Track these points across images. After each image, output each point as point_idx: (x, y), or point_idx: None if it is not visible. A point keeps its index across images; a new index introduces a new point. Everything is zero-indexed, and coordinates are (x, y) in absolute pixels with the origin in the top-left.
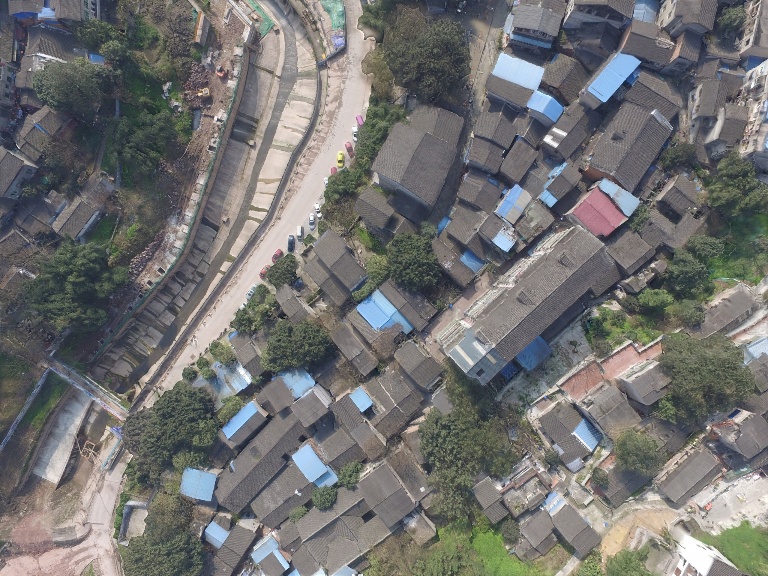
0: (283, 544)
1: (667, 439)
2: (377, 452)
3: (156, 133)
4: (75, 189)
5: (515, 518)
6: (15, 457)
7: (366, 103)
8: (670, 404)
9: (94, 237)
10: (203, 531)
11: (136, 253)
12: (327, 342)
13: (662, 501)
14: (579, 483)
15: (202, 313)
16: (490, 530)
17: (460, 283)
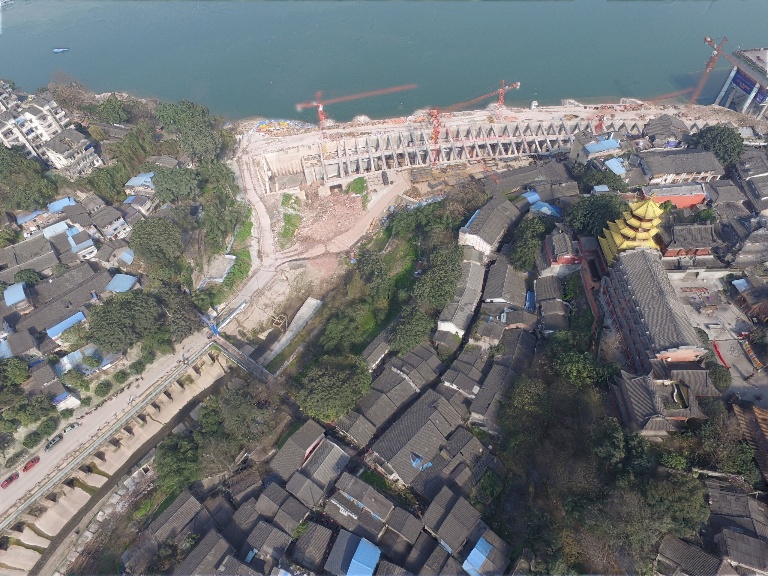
0: None
1: None
2: None
3: None
4: None
5: None
6: None
7: None
8: None
9: None
10: None
11: None
12: None
13: None
14: None
15: None
16: None
17: None
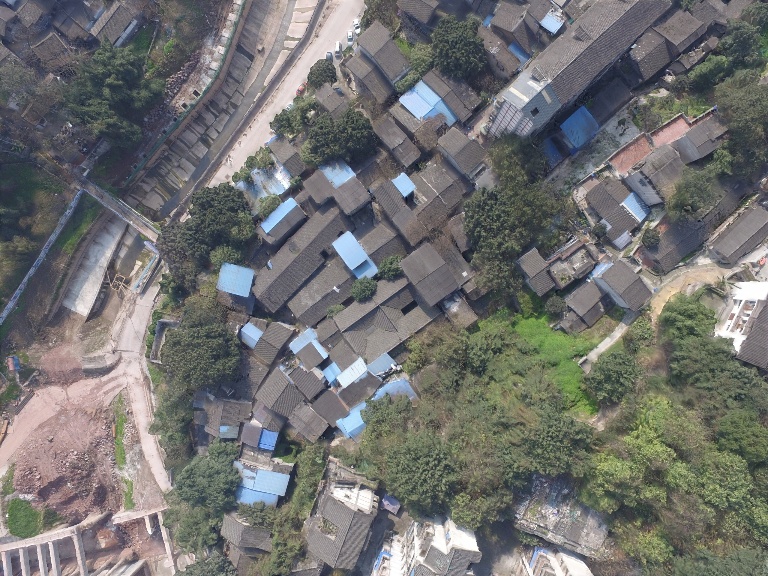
0: (321, 339)
1: (720, 199)
2: (419, 236)
3: None
4: None
5: (560, 295)
6: (46, 283)
7: None
8: (726, 151)
9: None
10: (239, 330)
11: (172, 72)
12: (370, 128)
13: (713, 264)
14: (626, 256)
15: (237, 134)
16: (533, 315)
17: (504, 75)
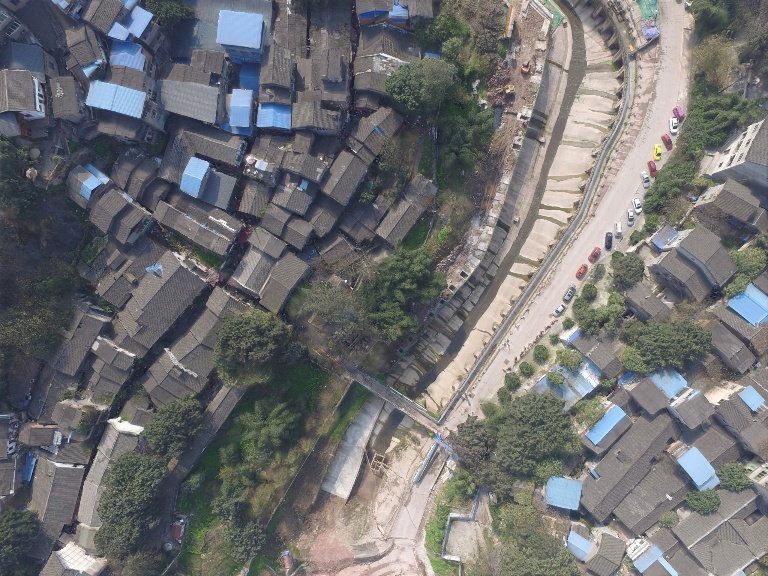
0: None
1: None
2: None
3: (481, 132)
4: (401, 193)
5: None
6: (313, 473)
7: (681, 93)
8: None
9: (409, 242)
10: (566, 541)
11: (442, 257)
12: (710, 340)
13: None
14: None
15: (511, 316)
16: None
17: None
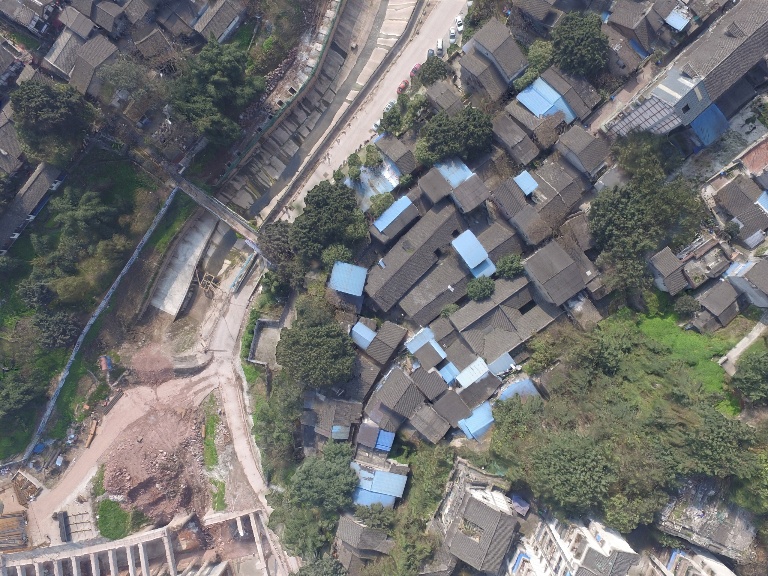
0: (436, 339)
1: None
2: (542, 235)
3: None
4: None
5: (691, 294)
6: (137, 282)
7: None
8: None
9: None
10: (351, 329)
11: (269, 69)
12: (490, 125)
13: None
14: (760, 255)
15: (335, 132)
16: (658, 315)
17: (624, 72)
